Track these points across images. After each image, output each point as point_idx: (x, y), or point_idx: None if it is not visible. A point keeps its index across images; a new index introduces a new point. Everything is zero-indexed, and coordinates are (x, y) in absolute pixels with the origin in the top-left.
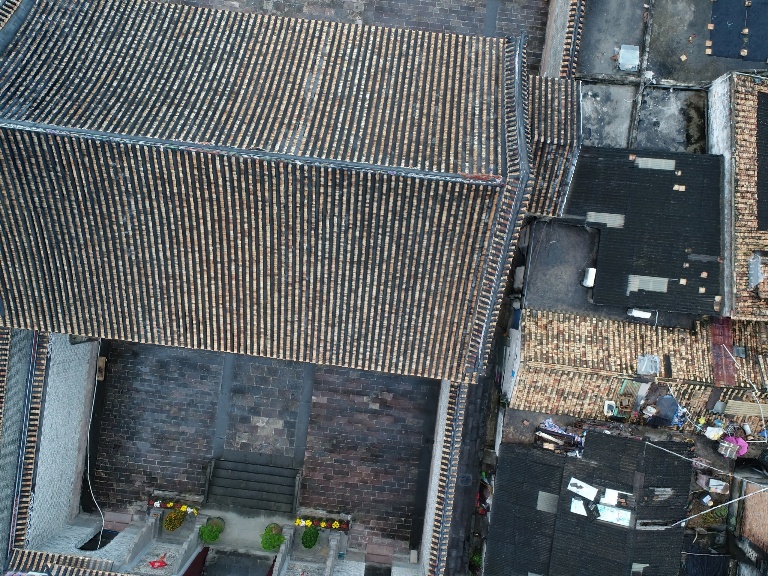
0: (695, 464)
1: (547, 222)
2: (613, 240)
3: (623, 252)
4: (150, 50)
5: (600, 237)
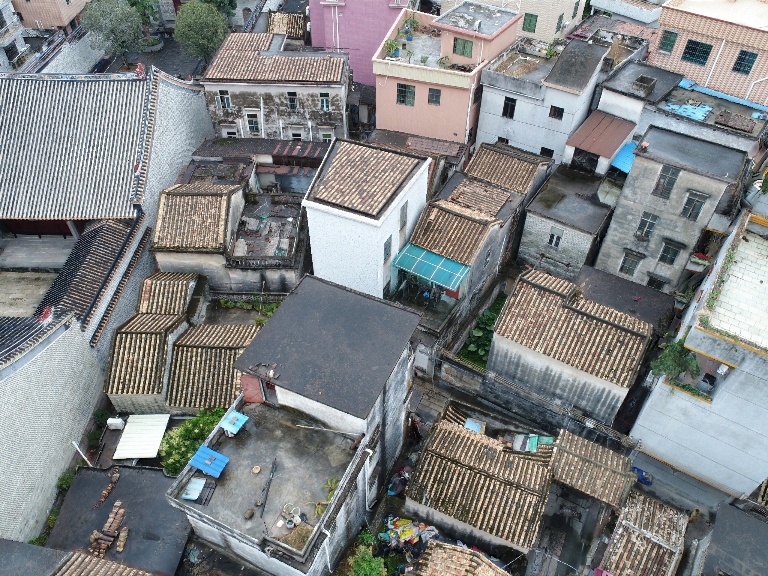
0: None
1: None
2: None
3: None
4: None
5: None
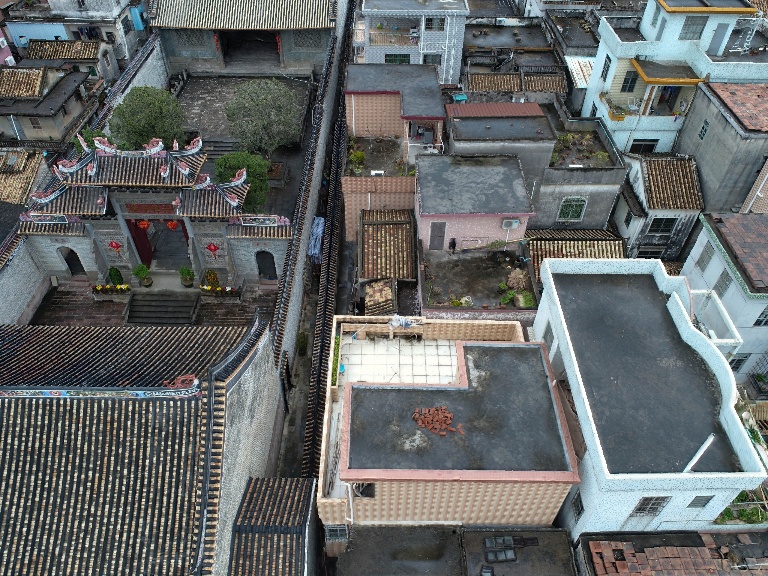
0: None
1: None
2: None
3: None
4: (64, 529)
5: None
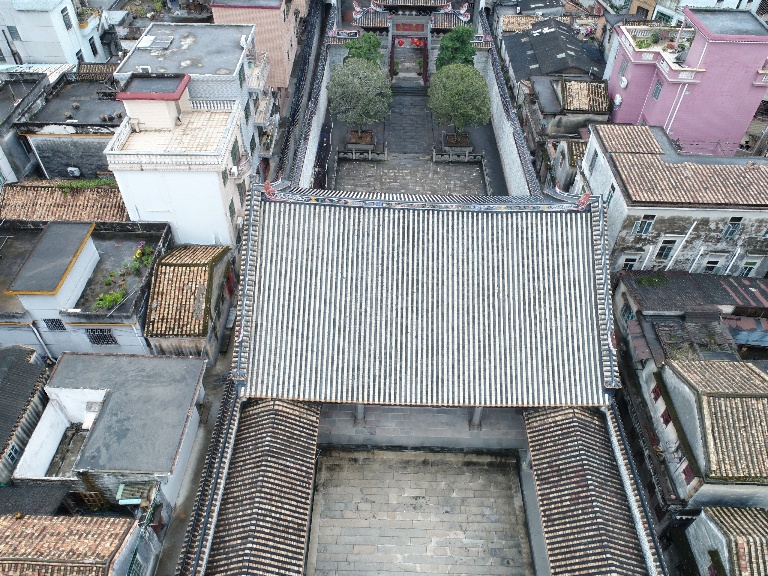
0: (572, 27)
1: (499, 4)
2: (522, 2)
3: (526, 3)
4: None
5: (518, 2)
